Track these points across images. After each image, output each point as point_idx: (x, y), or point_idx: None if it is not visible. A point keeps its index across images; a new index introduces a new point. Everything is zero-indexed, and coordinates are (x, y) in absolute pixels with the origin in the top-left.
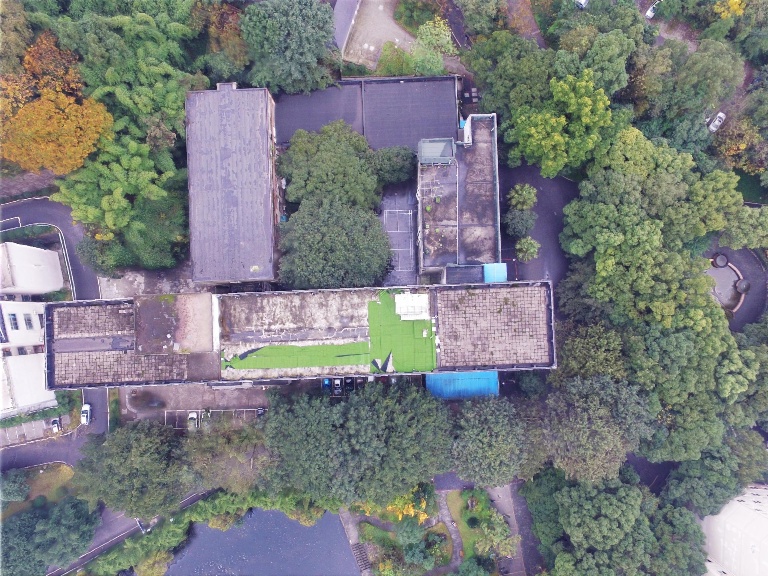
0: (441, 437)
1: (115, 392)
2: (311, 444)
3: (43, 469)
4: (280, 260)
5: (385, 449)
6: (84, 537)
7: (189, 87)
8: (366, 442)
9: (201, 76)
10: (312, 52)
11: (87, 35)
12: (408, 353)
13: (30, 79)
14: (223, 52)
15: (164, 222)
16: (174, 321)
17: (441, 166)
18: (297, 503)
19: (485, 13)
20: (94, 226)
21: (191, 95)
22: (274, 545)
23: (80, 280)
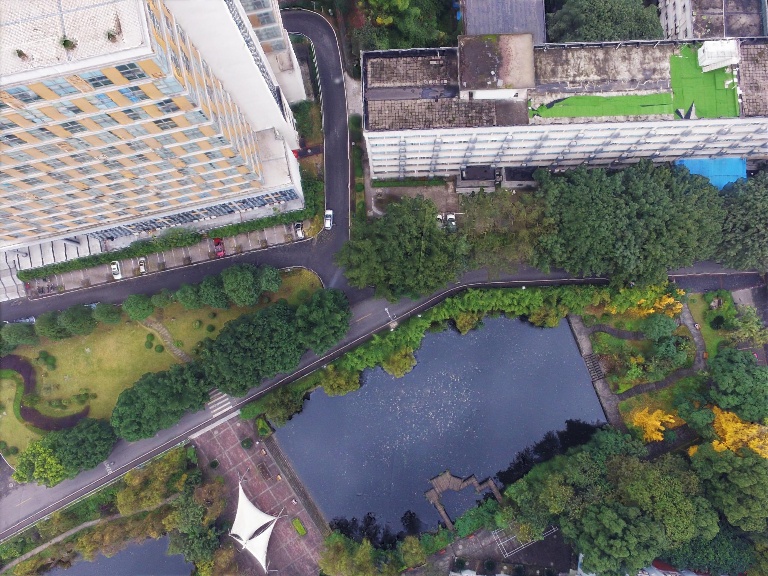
0: (716, 209)
1: (361, 195)
2: (600, 204)
3: (285, 273)
4: None
5: (674, 209)
6: (343, 323)
7: None
8: (654, 203)
9: None
10: None
11: None
12: (710, 103)
13: None
14: None
15: (423, 23)
16: (497, 59)
17: None
18: (543, 301)
19: None
20: (373, 11)
21: None
22: (506, 355)
23: (327, 89)
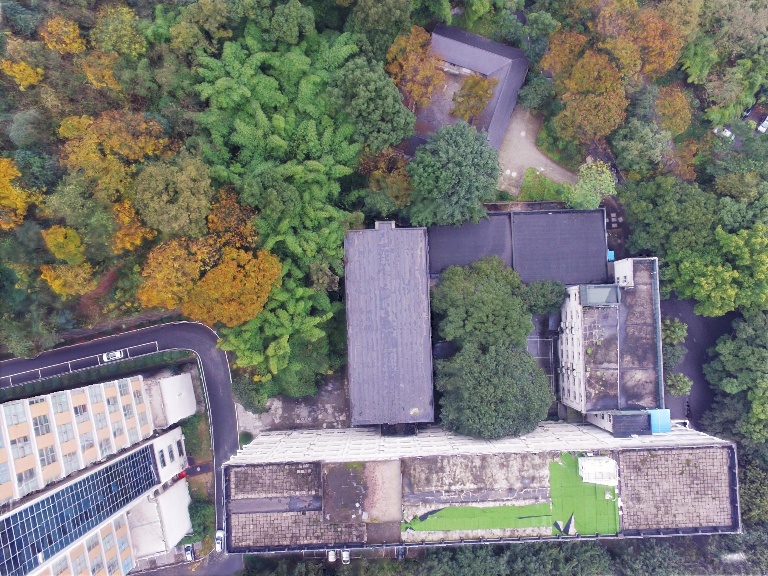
0: None
1: None
2: None
3: None
4: (440, 402)
5: None
6: None
7: (348, 225)
8: None
9: (358, 213)
10: (477, 196)
11: (268, 191)
12: (590, 515)
13: (215, 239)
14: (383, 191)
15: (312, 354)
16: (363, 489)
17: (601, 308)
18: None
19: (648, 158)
20: (251, 366)
21: (350, 234)
22: None
23: (217, 405)
